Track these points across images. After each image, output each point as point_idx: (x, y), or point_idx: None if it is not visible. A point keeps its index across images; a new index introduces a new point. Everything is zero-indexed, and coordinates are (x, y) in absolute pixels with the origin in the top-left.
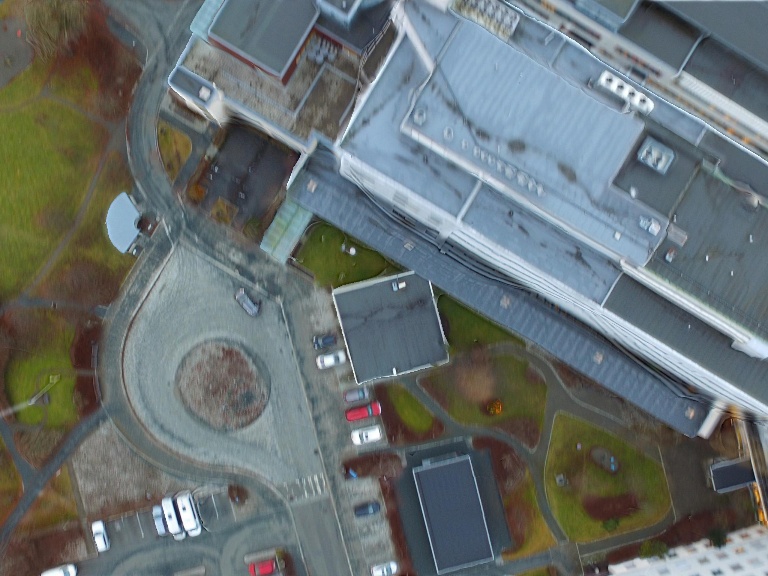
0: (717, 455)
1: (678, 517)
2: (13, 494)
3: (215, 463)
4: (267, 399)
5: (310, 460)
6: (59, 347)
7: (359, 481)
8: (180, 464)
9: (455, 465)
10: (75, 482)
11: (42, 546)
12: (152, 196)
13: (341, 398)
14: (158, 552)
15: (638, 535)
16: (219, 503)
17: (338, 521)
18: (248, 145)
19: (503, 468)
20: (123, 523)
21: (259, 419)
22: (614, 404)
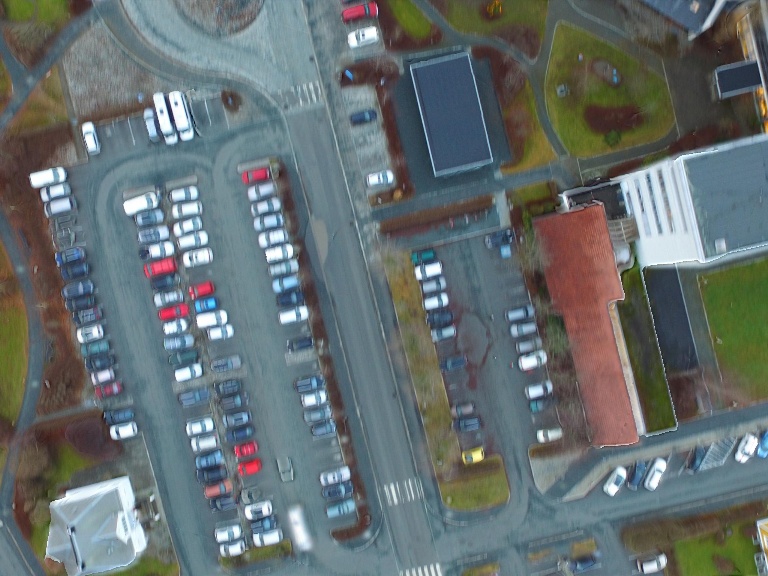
0: (722, 64)
1: (682, 134)
2: (2, 93)
3: (208, 68)
4: (262, 3)
5: (305, 67)
6: None
7: (355, 89)
8: (173, 68)
9: (453, 62)
10: (65, 84)
11: (31, 146)
12: None
13: (337, 2)
14: (149, 161)
15: (641, 151)
16: (212, 109)
17: (333, 131)
18: None
19: (503, 66)
20: (114, 129)
21: (253, 23)
22: (617, 14)
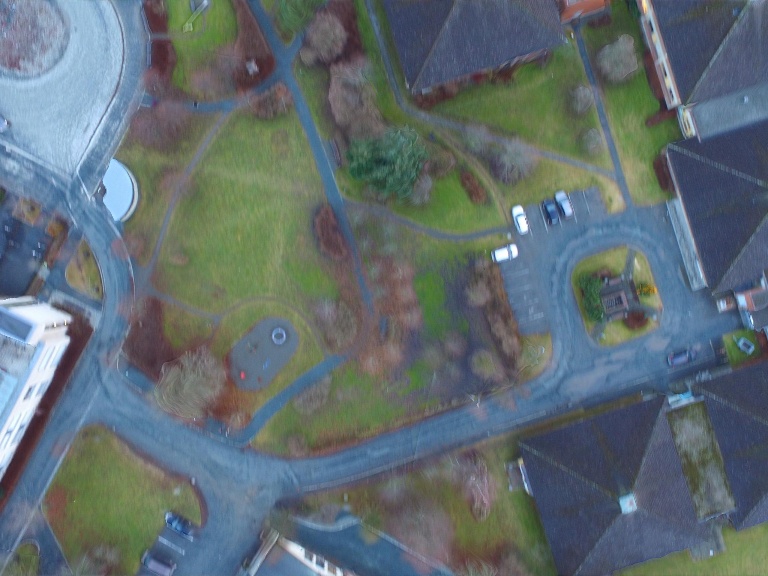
0: None
1: None
2: None
3: None
4: None
5: None
6: (189, 62)
7: None
8: None
9: None
10: None
11: None
12: (104, 223)
13: None
14: None
15: None
16: None
17: None
18: (7, 281)
19: None
20: None
21: None
22: None
